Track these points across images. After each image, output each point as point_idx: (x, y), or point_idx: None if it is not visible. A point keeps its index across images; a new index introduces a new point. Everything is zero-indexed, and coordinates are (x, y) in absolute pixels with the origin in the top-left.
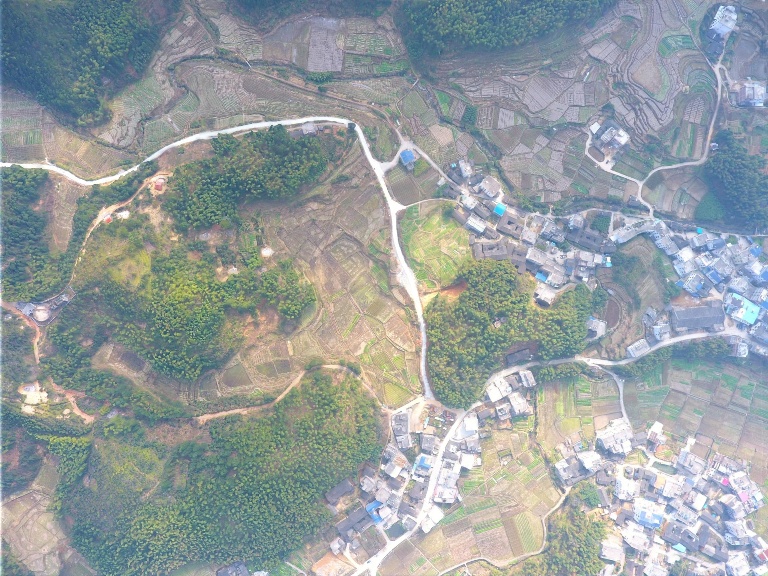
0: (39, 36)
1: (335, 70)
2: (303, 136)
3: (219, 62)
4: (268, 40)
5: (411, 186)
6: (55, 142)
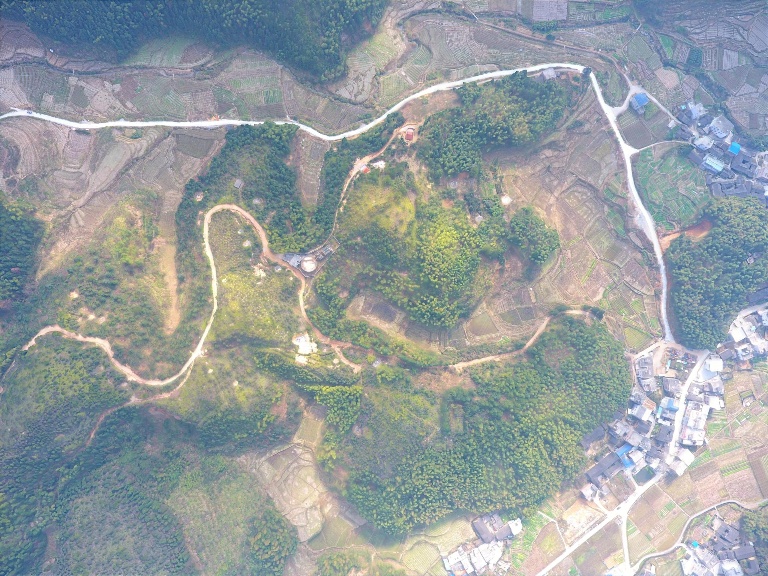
0: None
1: (560, 18)
2: (543, 82)
3: (447, 15)
4: None
5: (642, 130)
6: (295, 100)
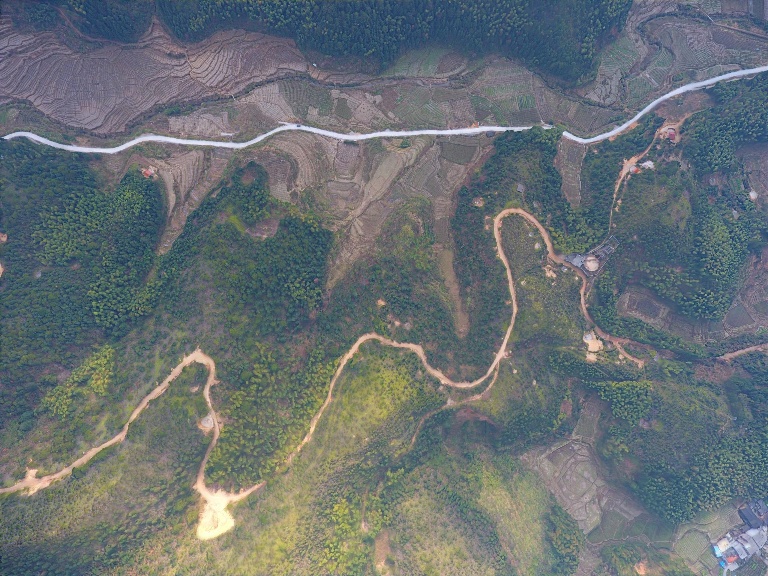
0: None
1: None
2: None
3: (683, 18)
4: None
5: None
6: (547, 105)
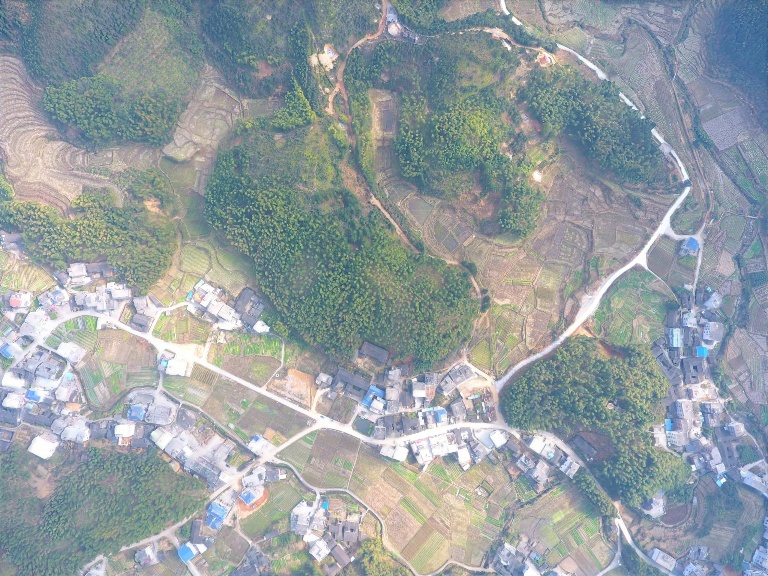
0: None
1: (717, 146)
2: None
3: (661, 54)
4: (704, 80)
5: (667, 263)
6: None
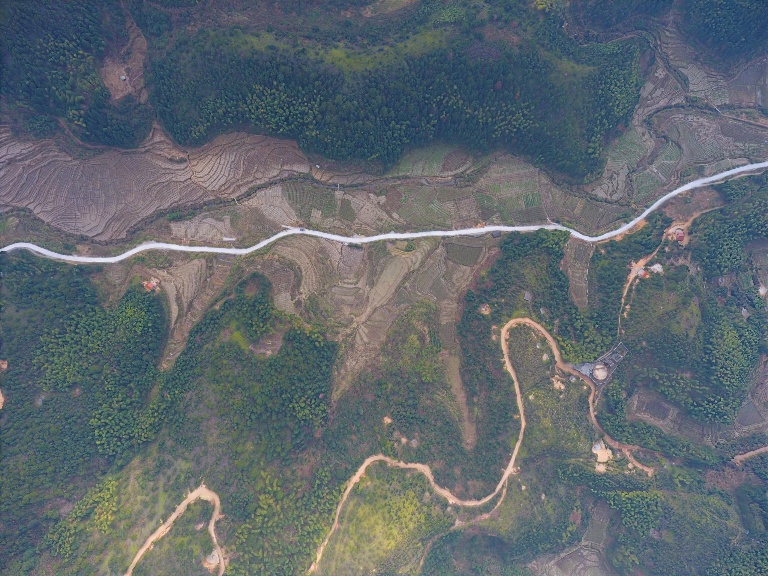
0: (571, 103)
1: None
2: None
3: (690, 110)
4: (732, 85)
5: None
6: (553, 202)
